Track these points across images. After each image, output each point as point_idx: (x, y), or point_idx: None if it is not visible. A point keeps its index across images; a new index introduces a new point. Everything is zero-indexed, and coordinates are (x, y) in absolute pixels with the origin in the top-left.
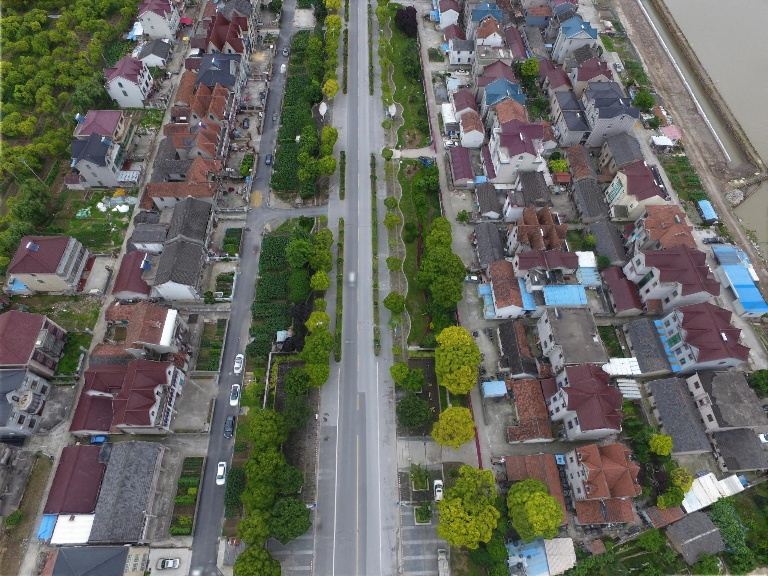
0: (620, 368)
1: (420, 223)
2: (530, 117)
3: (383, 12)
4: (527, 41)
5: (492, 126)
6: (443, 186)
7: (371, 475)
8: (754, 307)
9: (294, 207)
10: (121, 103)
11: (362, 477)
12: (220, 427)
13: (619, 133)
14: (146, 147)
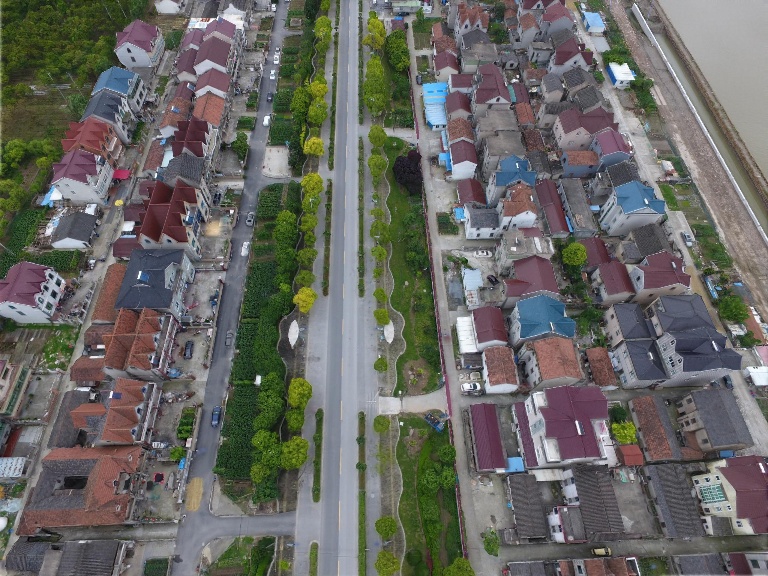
0: None
1: (429, 552)
2: (577, 332)
3: (378, 165)
4: (567, 203)
5: (528, 363)
6: (461, 468)
7: None
8: None
9: (247, 514)
10: (19, 320)
11: None
12: None
13: (711, 388)
14: (46, 397)
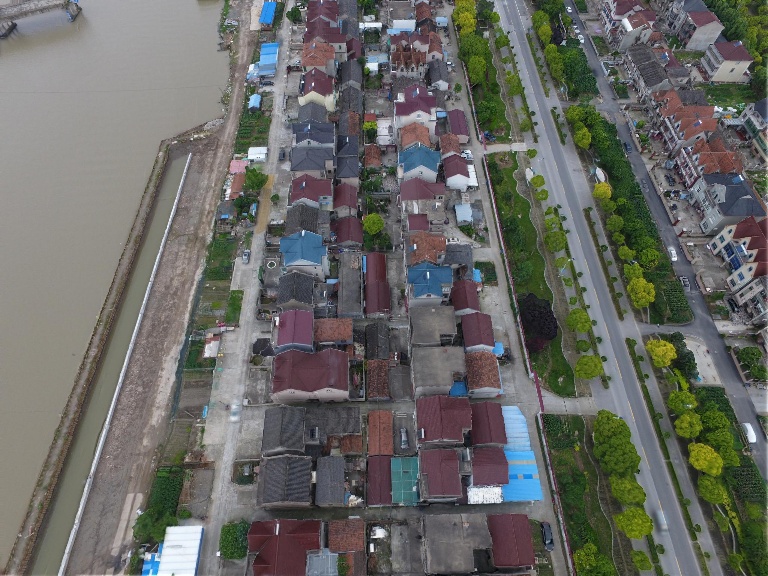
0: (371, 24)
1: None
2: None
3: None
4: None
5: None
6: (471, 121)
7: (500, 4)
8: (271, 45)
9: None
10: None
11: (504, 3)
12: (578, 22)
13: None
14: None
